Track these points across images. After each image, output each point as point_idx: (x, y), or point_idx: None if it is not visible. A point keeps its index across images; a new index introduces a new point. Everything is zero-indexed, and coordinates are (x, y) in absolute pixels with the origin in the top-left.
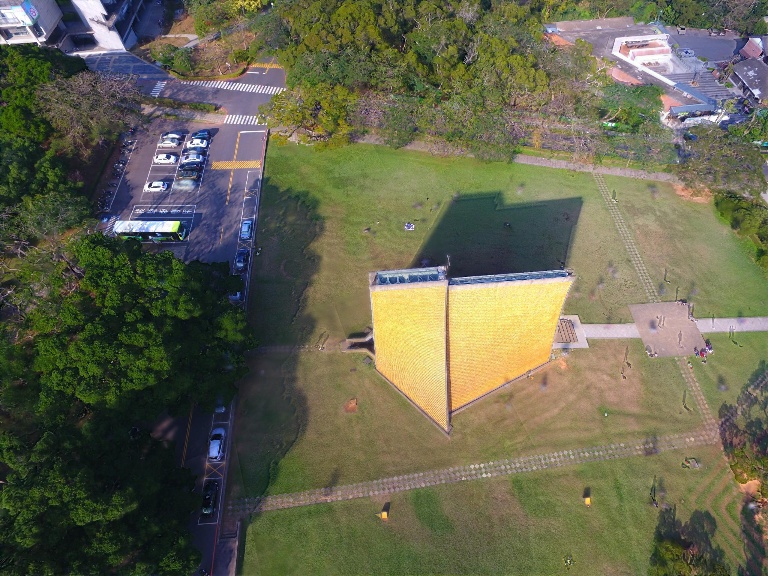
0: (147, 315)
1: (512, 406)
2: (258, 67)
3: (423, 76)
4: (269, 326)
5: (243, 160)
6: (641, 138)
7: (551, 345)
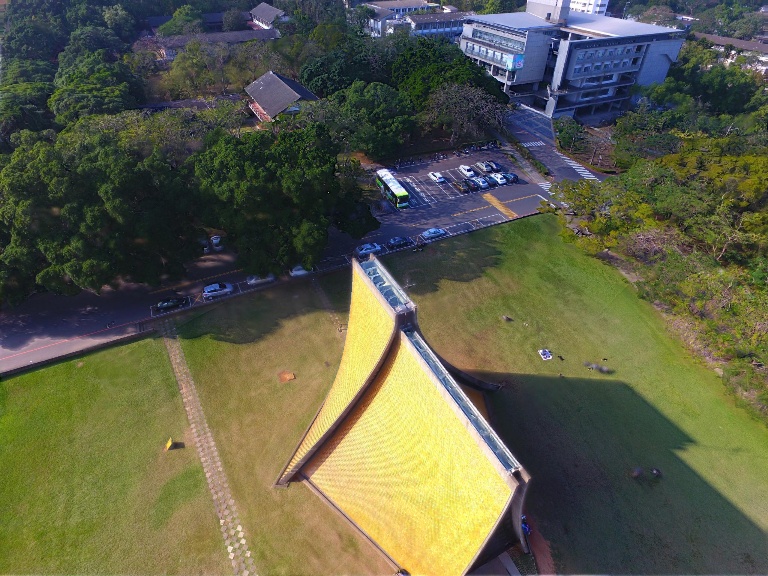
0: None
1: (341, 561)
2: None
3: None
4: (344, 284)
5: (508, 207)
6: None
7: None
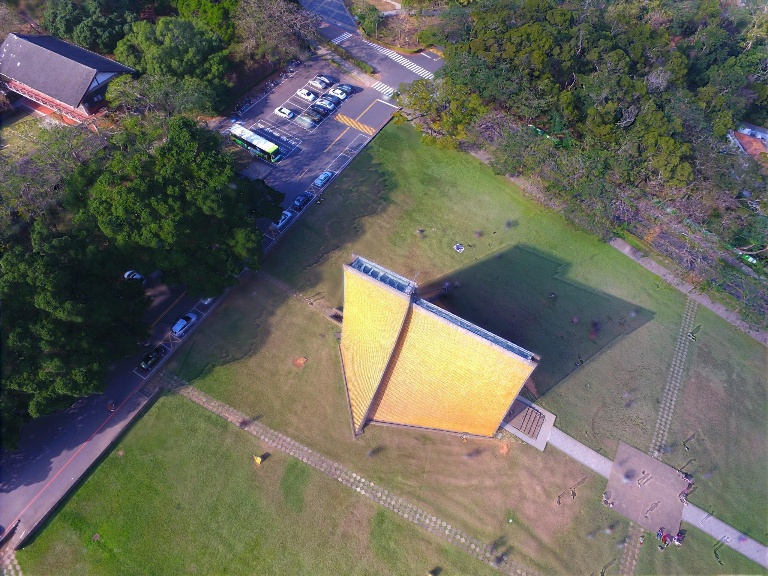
0: (184, 196)
1: (427, 451)
2: (434, 52)
3: (569, 120)
4: (285, 262)
5: (363, 123)
6: (764, 287)
7: (499, 422)
